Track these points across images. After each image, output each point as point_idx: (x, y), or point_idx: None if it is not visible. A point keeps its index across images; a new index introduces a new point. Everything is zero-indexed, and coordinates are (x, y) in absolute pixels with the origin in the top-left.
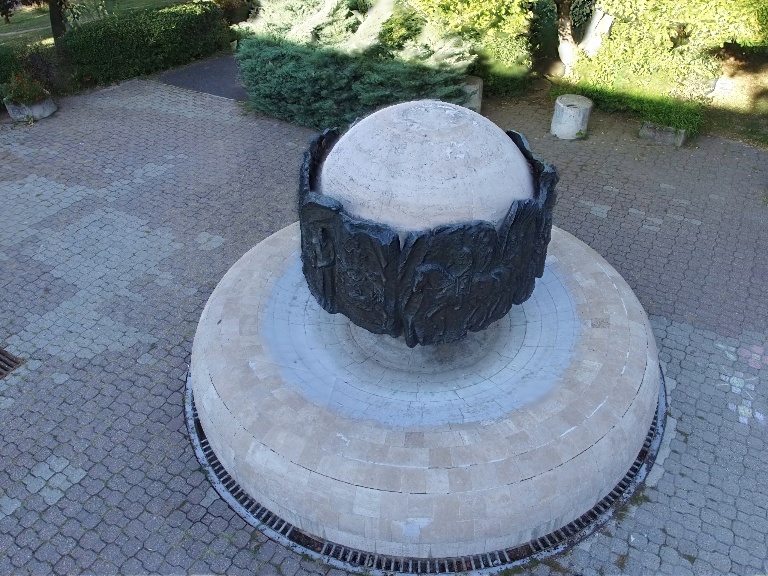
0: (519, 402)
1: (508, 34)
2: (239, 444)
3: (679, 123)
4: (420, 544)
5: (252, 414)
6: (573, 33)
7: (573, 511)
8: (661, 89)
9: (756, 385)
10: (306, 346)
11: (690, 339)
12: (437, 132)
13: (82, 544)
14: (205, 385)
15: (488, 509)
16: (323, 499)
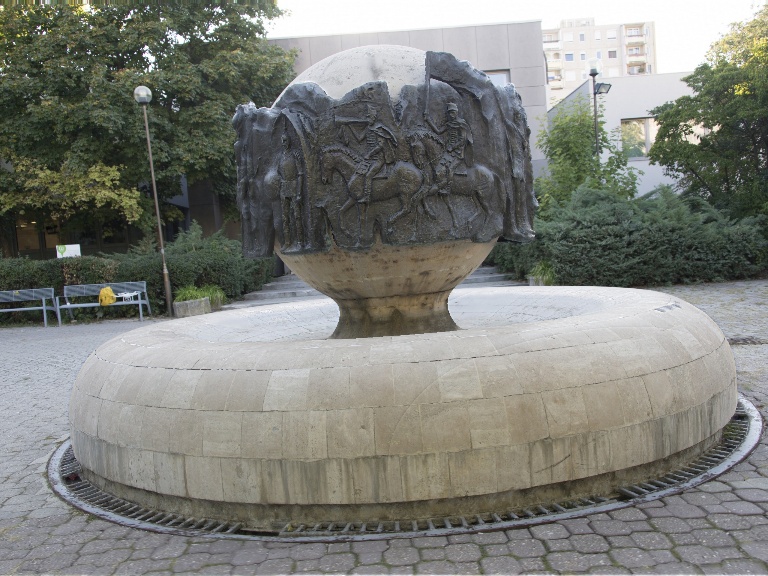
0: (245, 319)
1: None
2: None
3: None
4: None
5: None
6: None
7: None
8: None
9: None
10: None
11: None
12: None
13: None
14: None
15: None
16: None
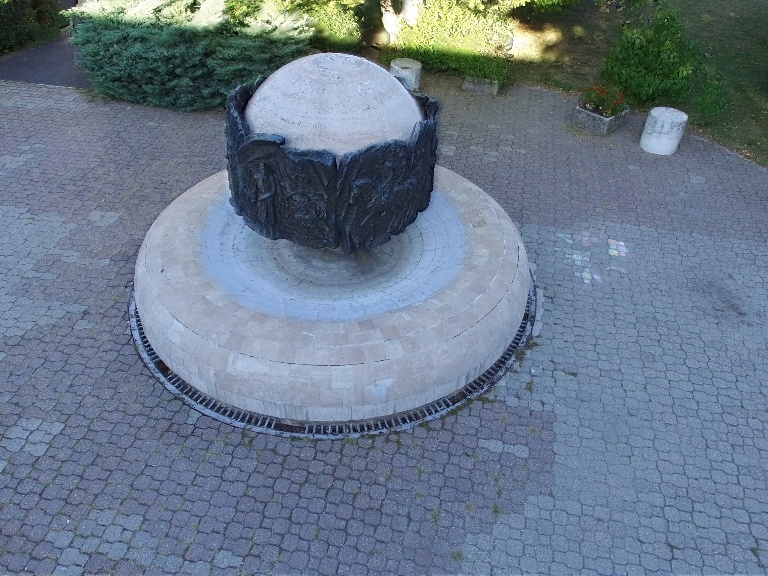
0: (436, 287)
1: (346, 5)
2: (218, 360)
3: (492, 75)
4: (387, 402)
5: (224, 333)
6: (393, 5)
7: (491, 357)
8: (473, 49)
9: (590, 257)
10: (247, 279)
11: (538, 234)
12: (346, 74)
13: (86, 477)
14: (168, 322)
15: (434, 362)
16: (305, 383)
